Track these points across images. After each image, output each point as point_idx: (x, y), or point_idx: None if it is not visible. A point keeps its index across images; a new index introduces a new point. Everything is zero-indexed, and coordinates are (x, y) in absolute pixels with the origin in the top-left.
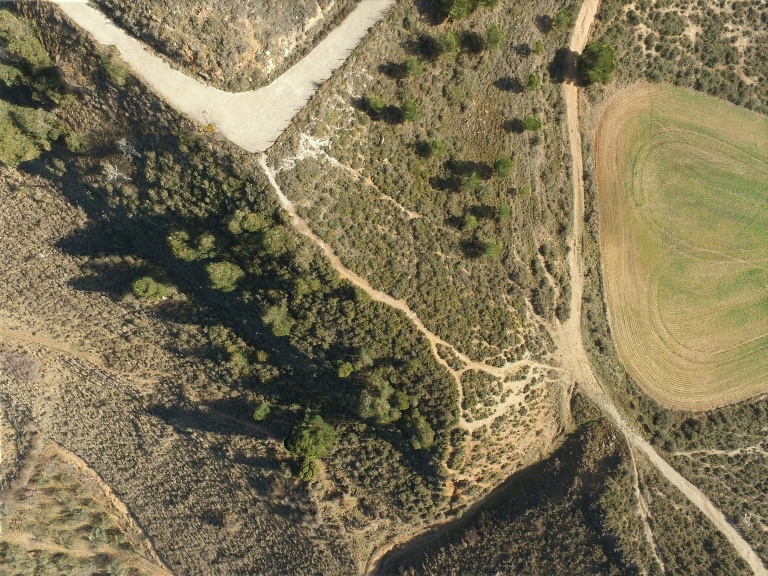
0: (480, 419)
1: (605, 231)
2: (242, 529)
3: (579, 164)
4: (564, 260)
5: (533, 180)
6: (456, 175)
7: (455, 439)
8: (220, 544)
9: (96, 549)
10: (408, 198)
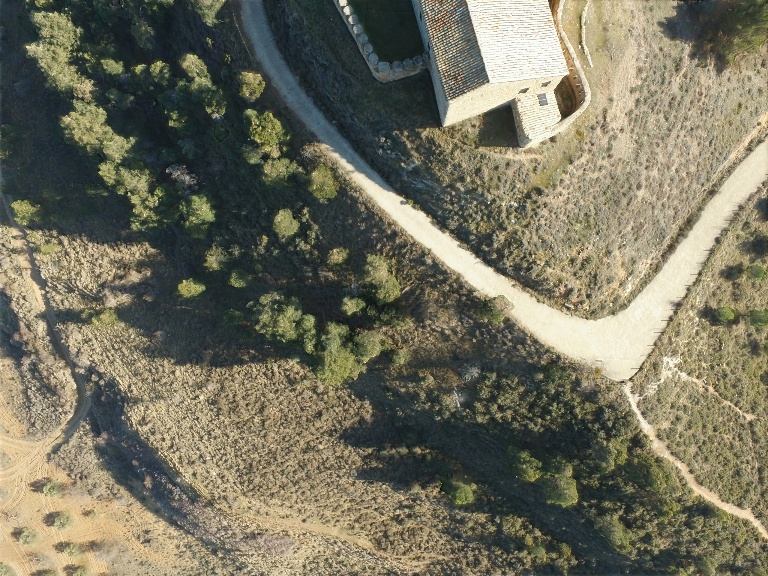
0: None
1: None
2: None
3: None
4: None
5: None
6: None
7: None
8: None
9: None
10: (745, 400)
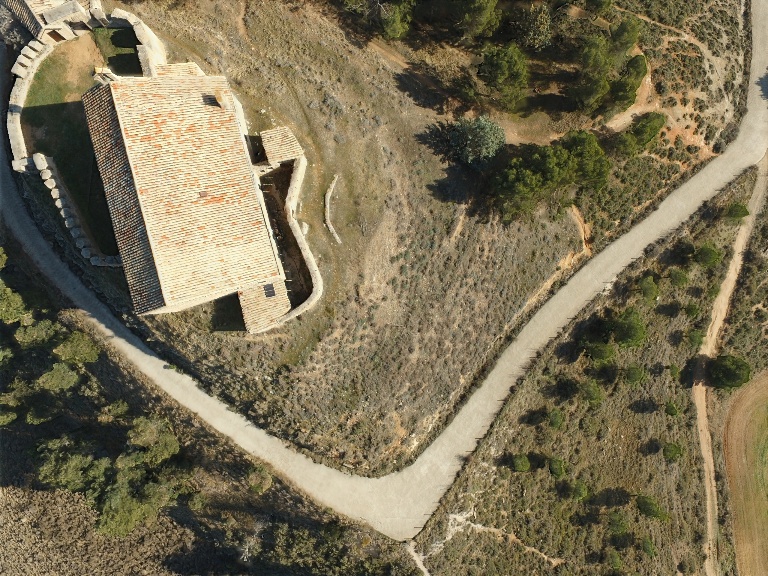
0: None
1: (738, 528)
2: None
3: (710, 464)
4: (701, 569)
5: (670, 499)
6: (594, 506)
7: None
8: None
9: None
10: (551, 545)
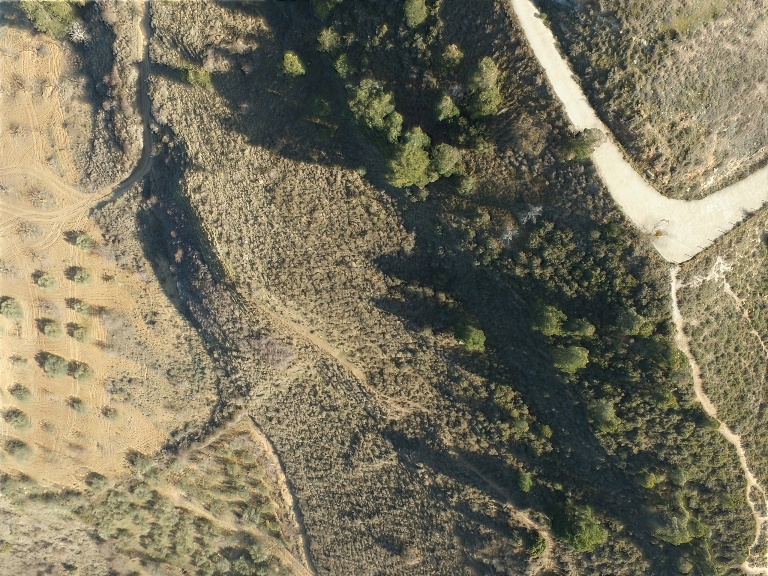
0: (761, 567)
1: None
2: (417, 564)
3: None
4: None
5: None
6: None
7: None
8: (383, 568)
9: (241, 525)
10: None
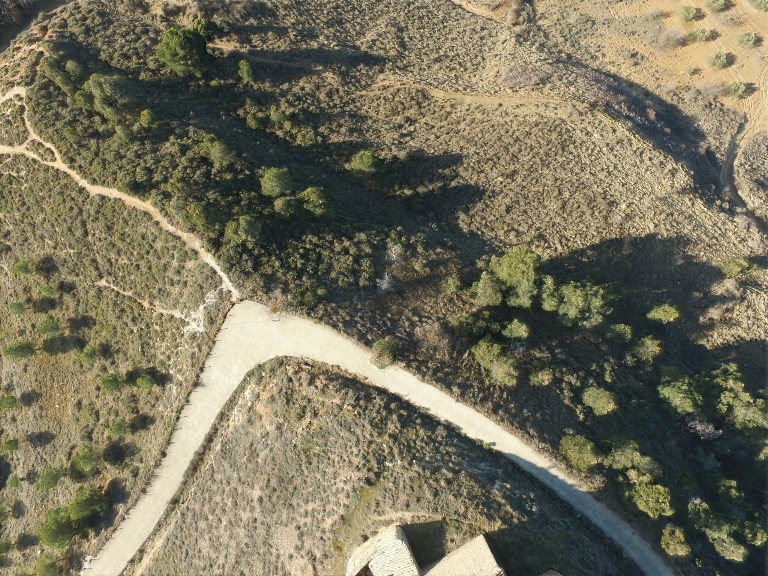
0: (7, 100)
1: None
2: None
3: None
4: None
5: (4, 349)
6: (76, 335)
7: (31, 77)
8: None
9: None
10: (109, 298)
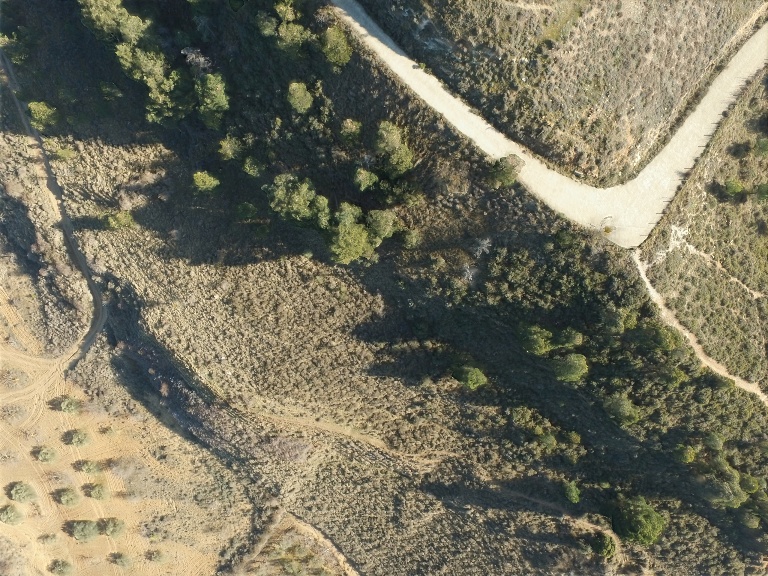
0: None
1: None
2: None
3: None
4: None
5: None
6: None
7: None
8: None
9: None
10: (752, 278)
